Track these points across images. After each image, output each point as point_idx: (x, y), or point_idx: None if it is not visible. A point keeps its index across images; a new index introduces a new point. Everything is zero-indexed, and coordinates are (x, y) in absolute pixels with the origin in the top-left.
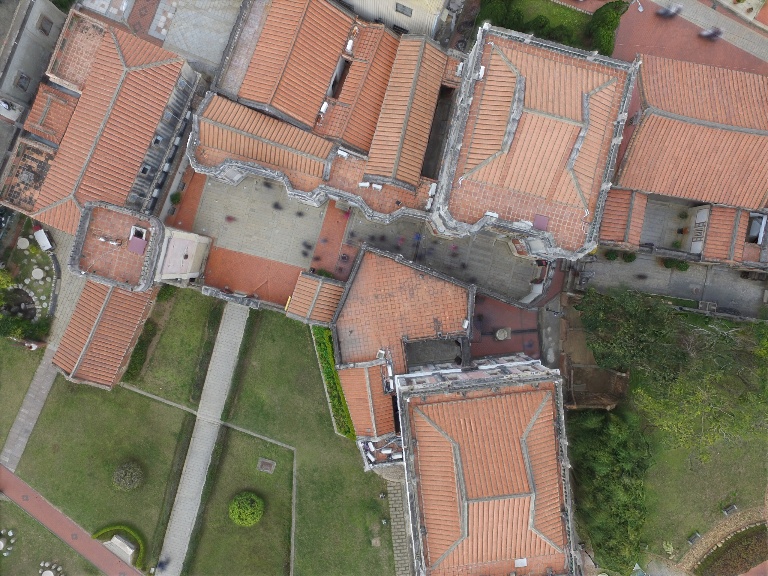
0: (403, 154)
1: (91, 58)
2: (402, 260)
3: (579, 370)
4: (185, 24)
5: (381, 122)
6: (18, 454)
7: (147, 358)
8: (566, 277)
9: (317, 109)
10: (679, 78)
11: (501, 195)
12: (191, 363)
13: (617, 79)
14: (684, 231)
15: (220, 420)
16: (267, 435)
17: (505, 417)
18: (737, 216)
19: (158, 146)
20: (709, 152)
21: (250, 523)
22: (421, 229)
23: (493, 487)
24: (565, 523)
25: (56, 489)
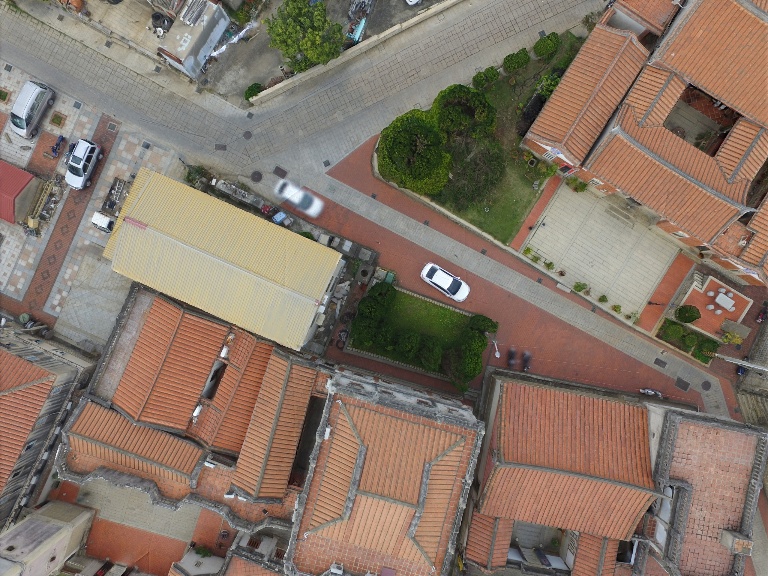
0: (267, 471)
1: None
2: (268, 568)
3: None
4: (79, 302)
5: (250, 433)
6: None
7: None
8: None
9: (190, 412)
10: (542, 411)
11: (348, 548)
12: None
13: (465, 438)
14: (562, 532)
15: None
16: None
17: None
18: (604, 545)
19: (32, 447)
20: (569, 492)
21: None
22: None
23: None
24: None
25: None
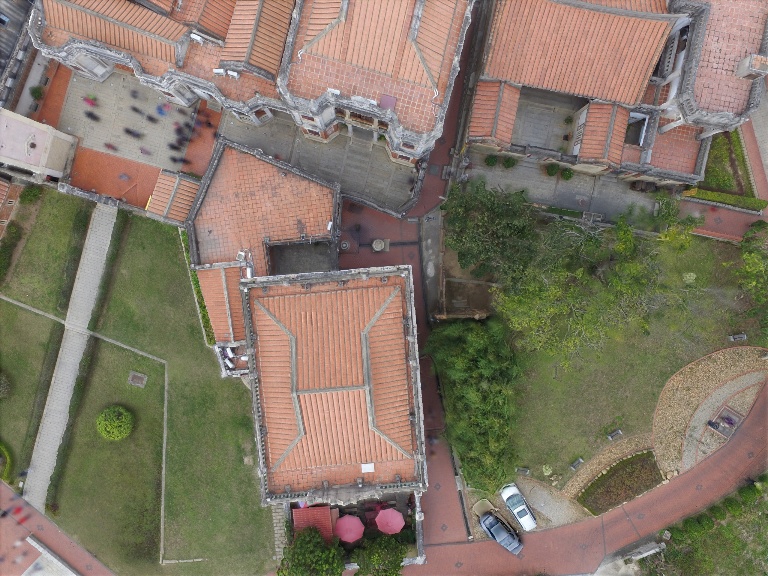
0: (258, 38)
1: None
2: (261, 155)
3: (460, 285)
4: None
5: (238, 5)
6: None
7: (12, 263)
8: (447, 186)
9: None
10: None
11: (345, 72)
12: (58, 269)
13: None
14: (568, 136)
15: (89, 330)
16: (138, 347)
17: (349, 311)
18: (613, 112)
19: (4, 27)
20: (578, 37)
21: (117, 436)
22: (296, 132)
23: (326, 379)
24: (415, 427)
25: None
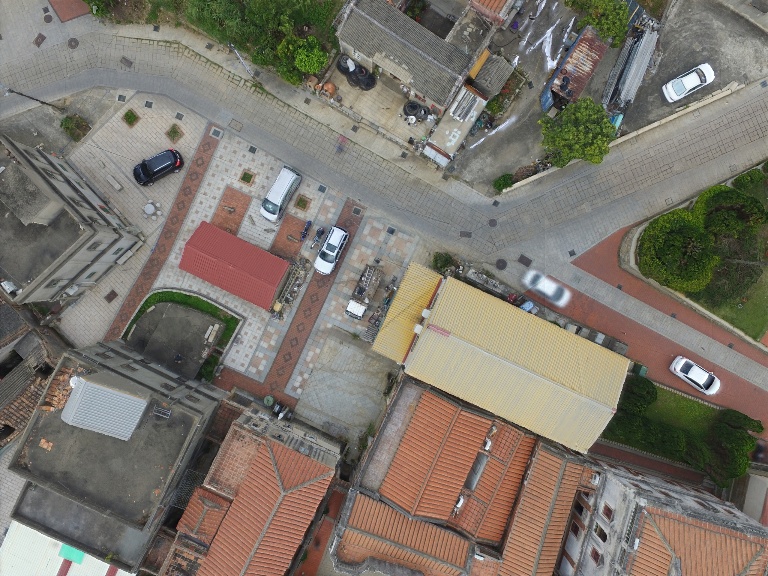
0: (539, 565)
1: (245, 465)
2: None
3: None
4: (320, 385)
5: (517, 526)
6: None
7: None
8: None
9: (453, 503)
10: None
11: None
12: None
13: (764, 547)
14: None
15: None
16: None
17: None
18: None
19: None
20: None
21: None
22: None
23: None
24: None
25: None
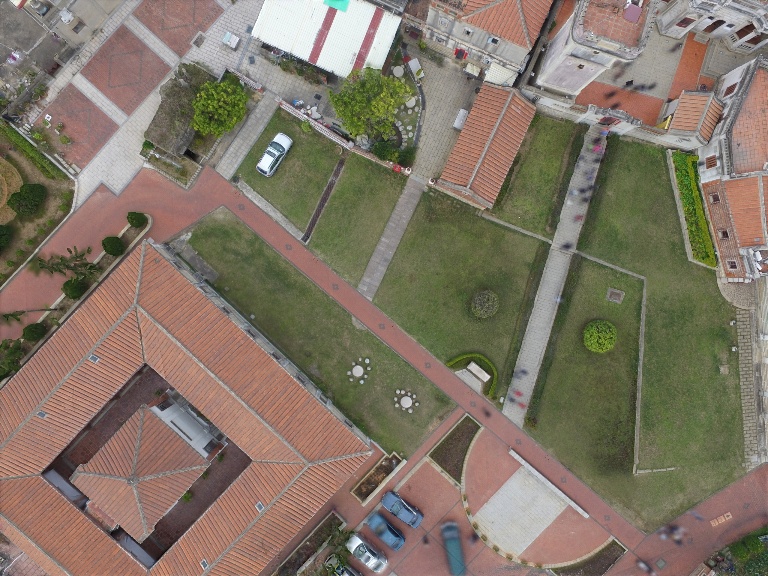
0: None
1: None
2: None
3: None
4: None
5: None
6: (376, 283)
7: None
8: None
9: None
10: None
11: None
12: (549, 192)
13: None
14: None
15: (574, 249)
16: (619, 264)
17: None
18: None
19: None
20: None
21: (607, 348)
22: None
23: None
24: None
25: (412, 318)
